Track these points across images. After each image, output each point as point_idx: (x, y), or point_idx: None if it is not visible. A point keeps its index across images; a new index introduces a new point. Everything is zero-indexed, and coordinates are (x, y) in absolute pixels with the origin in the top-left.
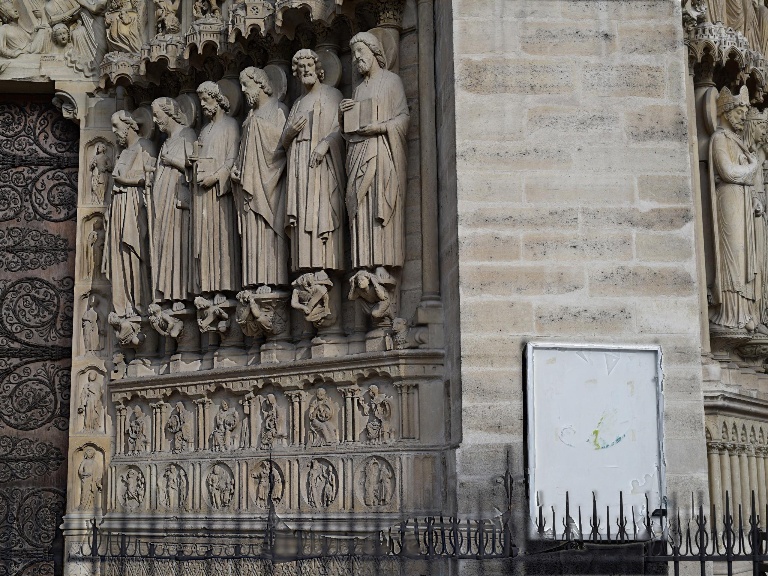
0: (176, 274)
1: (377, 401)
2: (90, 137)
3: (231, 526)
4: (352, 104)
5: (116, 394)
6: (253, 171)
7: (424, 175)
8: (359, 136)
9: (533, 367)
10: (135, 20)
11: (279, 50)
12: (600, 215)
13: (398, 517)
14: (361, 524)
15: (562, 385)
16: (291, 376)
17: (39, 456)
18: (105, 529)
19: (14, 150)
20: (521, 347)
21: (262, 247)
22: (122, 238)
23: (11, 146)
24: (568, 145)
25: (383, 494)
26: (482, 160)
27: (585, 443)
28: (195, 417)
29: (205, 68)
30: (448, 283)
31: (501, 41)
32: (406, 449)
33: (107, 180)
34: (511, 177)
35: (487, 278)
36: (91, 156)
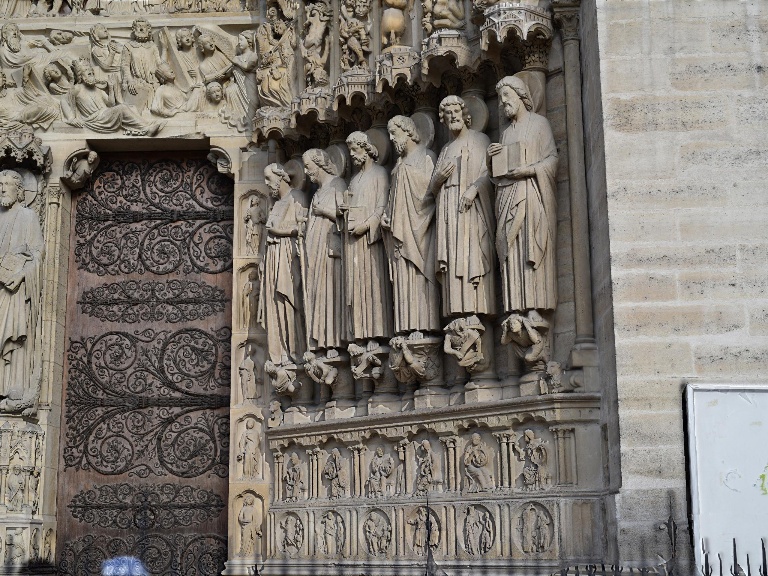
0: (329, 322)
1: (533, 446)
2: (244, 190)
3: (389, 573)
4: (500, 148)
5: (273, 441)
6: (403, 218)
7: (574, 216)
8: (508, 180)
9: (694, 410)
10: (285, 75)
11: (426, 98)
12: (759, 252)
13: (557, 564)
14: (520, 571)
15: (725, 428)
16: (445, 422)
17: (201, 503)
18: (265, 575)
19: (172, 205)
20: (680, 389)
21: (413, 293)
22: (276, 288)
23: (169, 202)
24: (723, 181)
25: (541, 541)
26: (634, 199)
27: (751, 488)
28: (351, 463)
29: (353, 119)
30: (602, 325)
31: (650, 79)
32: (564, 495)
33: (261, 231)
34: (664, 216)
35: (643, 319)
36: (245, 209)
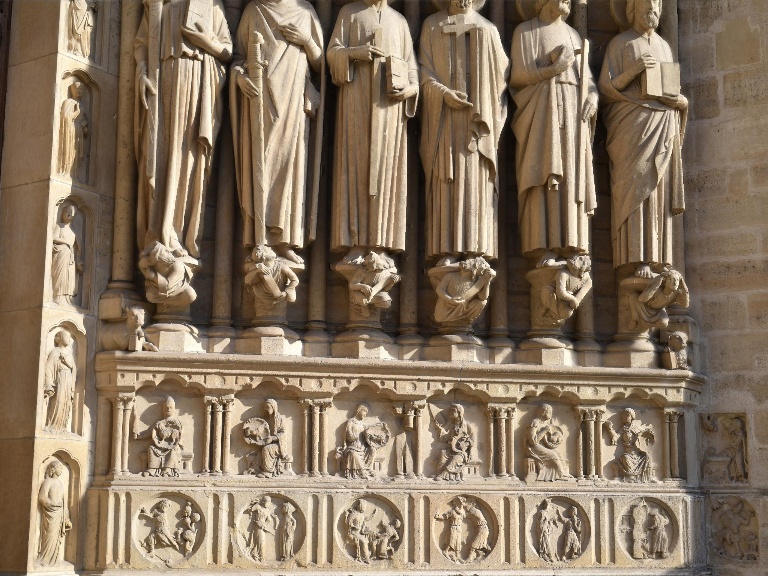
0: (300, 208)
1: (635, 429)
2: None
3: None
4: (655, 62)
5: (129, 374)
6: None
7: None
8: (660, 103)
9: None
10: None
11: None
12: None
13: None
14: None
15: None
16: (508, 384)
17: None
18: None
19: None
20: None
21: None
22: (202, 130)
23: None
24: None
25: (660, 545)
26: None
27: None
28: (298, 424)
29: None
30: (741, 301)
31: None
32: None
33: None
34: None
35: None
36: None
